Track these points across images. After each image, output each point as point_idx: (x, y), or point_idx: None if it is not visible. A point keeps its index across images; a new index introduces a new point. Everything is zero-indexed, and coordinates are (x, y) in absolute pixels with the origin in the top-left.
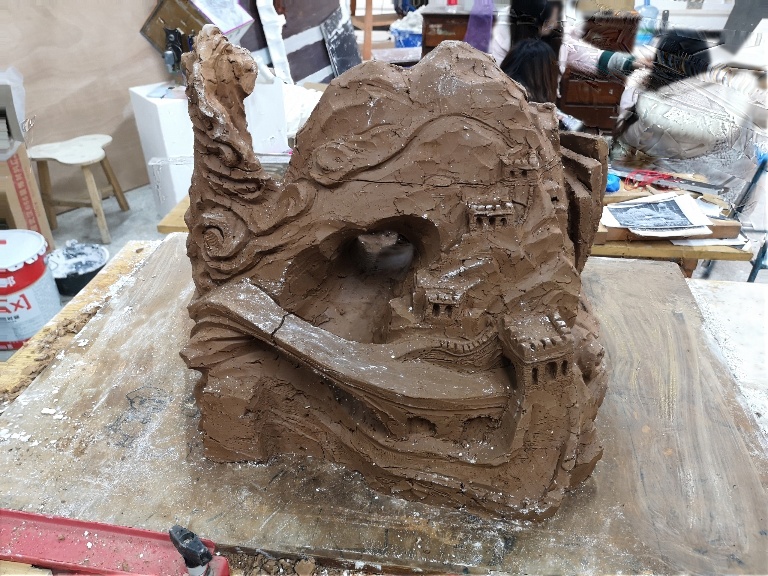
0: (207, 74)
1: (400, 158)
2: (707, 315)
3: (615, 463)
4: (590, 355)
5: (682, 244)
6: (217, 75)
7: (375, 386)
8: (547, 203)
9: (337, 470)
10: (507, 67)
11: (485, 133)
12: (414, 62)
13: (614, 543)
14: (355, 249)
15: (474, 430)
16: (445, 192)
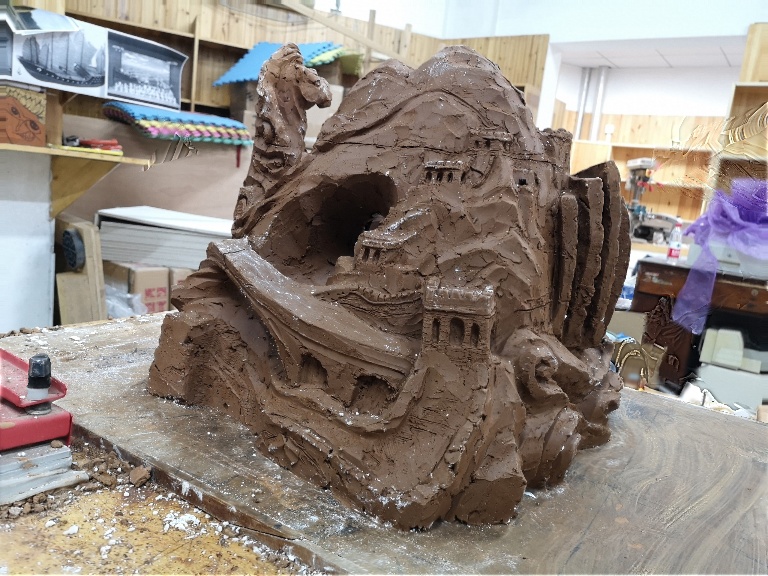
0: (272, 68)
1: (383, 126)
2: None
3: (550, 527)
4: (530, 356)
5: None
6: (281, 73)
7: (277, 304)
8: (507, 175)
9: (241, 429)
10: (709, 304)
11: (460, 108)
12: None
13: None
14: None
15: (371, 401)
16: (409, 152)
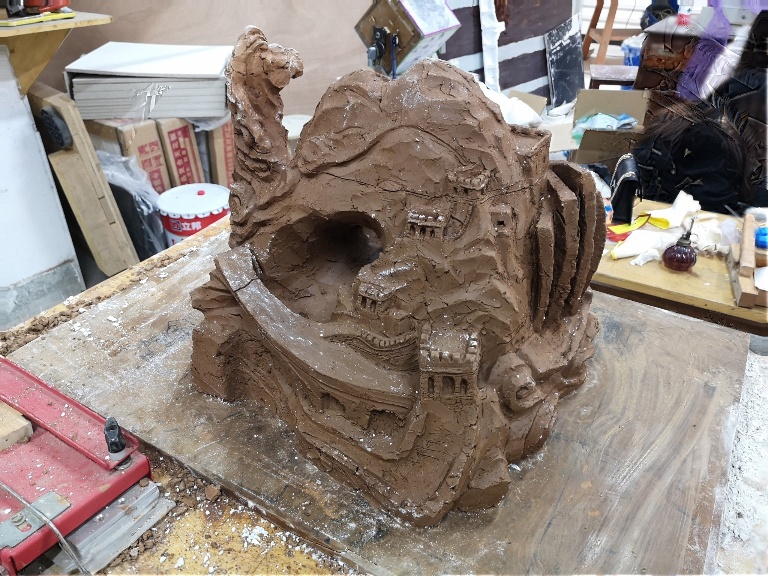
0: (237, 67)
1: (363, 159)
2: (755, 398)
3: (530, 504)
4: (511, 385)
5: None
6: (248, 69)
7: (294, 355)
8: (485, 224)
9: (280, 426)
10: None
11: (437, 148)
12: (633, 82)
13: (476, 571)
14: (353, 239)
15: (384, 423)
16: (392, 197)
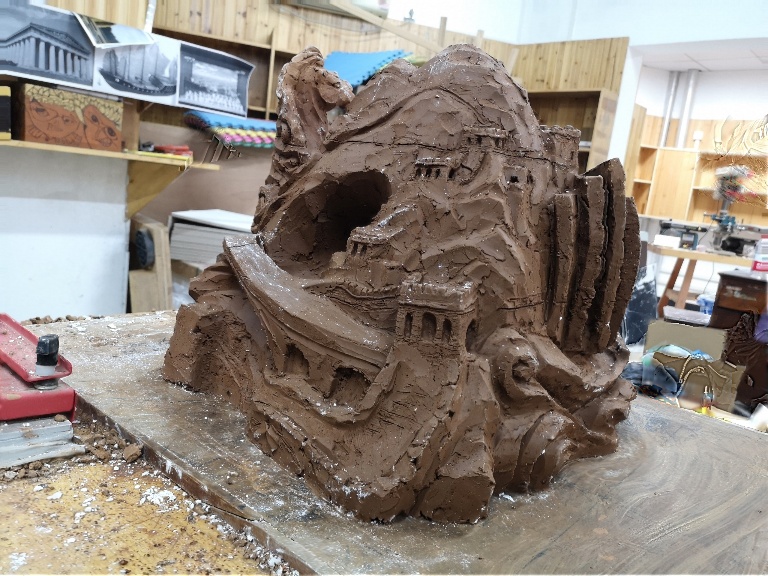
0: (291, 71)
1: (384, 125)
2: None
3: (519, 531)
4: (508, 355)
5: None
6: (301, 76)
7: (267, 295)
8: (496, 172)
9: (238, 417)
10: None
11: (456, 105)
12: None
13: (424, 574)
14: None
15: (350, 393)
16: (404, 150)
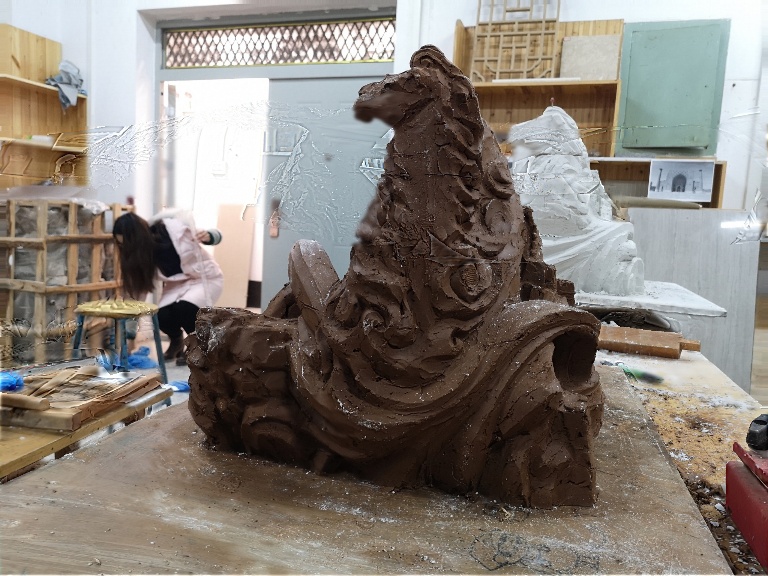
0: None
1: None
2: None
3: None
4: None
5: (129, 401)
6: None
7: None
8: None
9: None
10: None
11: None
12: None
13: None
14: None
15: None
16: None
